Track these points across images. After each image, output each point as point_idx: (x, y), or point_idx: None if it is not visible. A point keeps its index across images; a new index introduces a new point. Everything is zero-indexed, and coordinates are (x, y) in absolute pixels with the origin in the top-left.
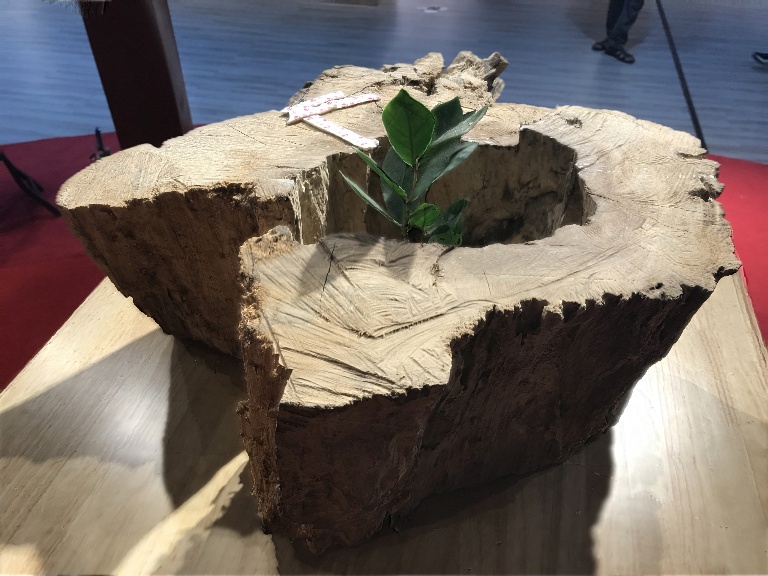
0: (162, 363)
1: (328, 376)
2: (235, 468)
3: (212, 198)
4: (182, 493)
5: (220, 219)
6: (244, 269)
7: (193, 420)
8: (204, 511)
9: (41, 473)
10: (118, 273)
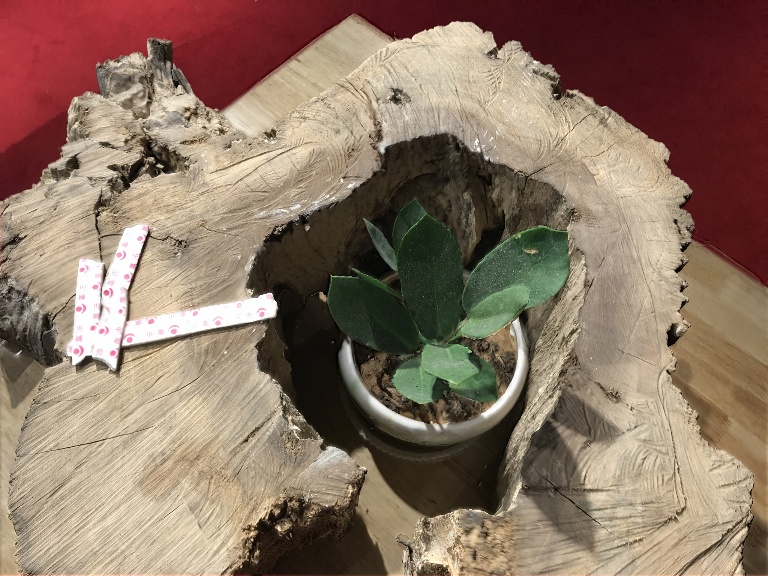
0: None
1: (710, 575)
2: None
3: (258, 559)
4: None
5: None
6: None
7: None
8: None
9: None
10: None
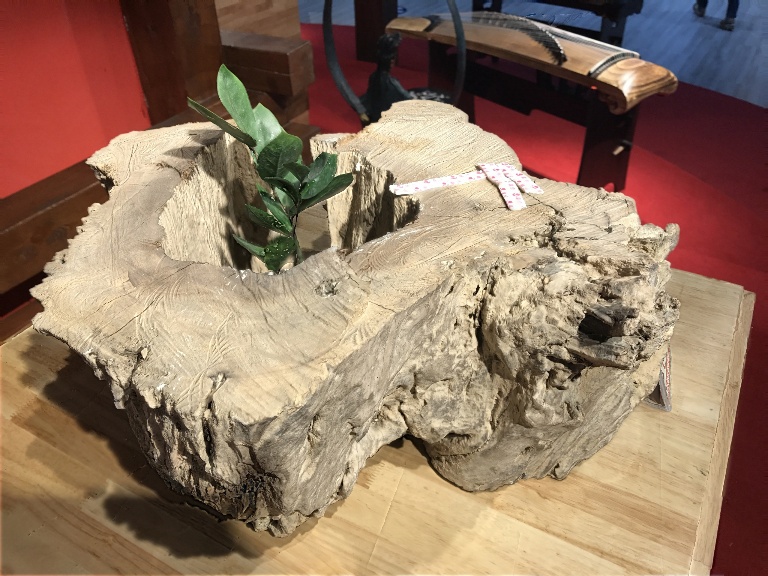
0: None
1: None
2: None
3: None
4: None
5: None
6: None
7: None
8: None
9: None
10: None
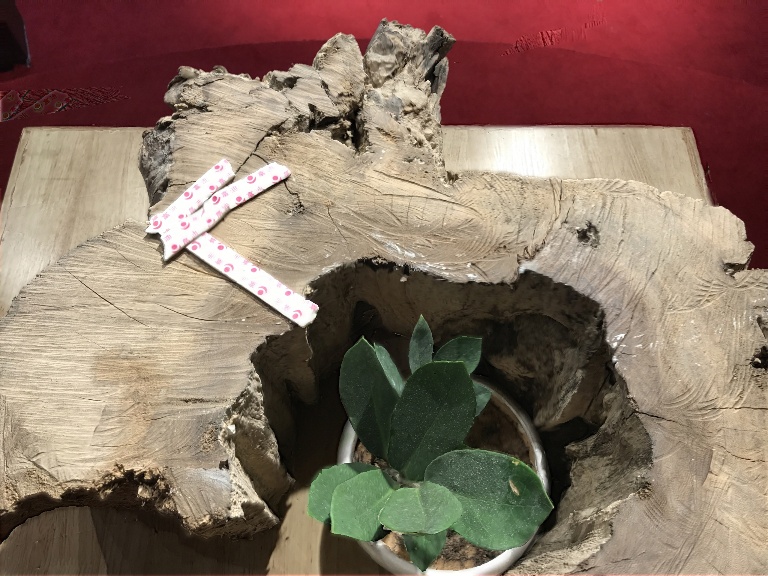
0: (84, 533)
1: None
2: None
3: (106, 496)
4: None
5: None
6: None
7: None
8: None
9: None
10: None
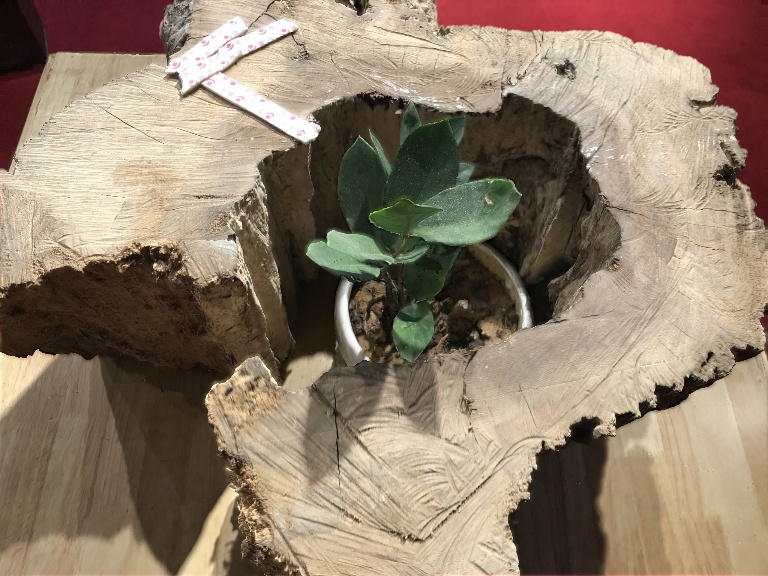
0: (94, 391)
1: None
2: (223, 512)
3: (124, 271)
4: (174, 557)
5: (138, 282)
6: (224, 446)
7: (157, 461)
8: (205, 573)
9: (3, 570)
10: (15, 347)
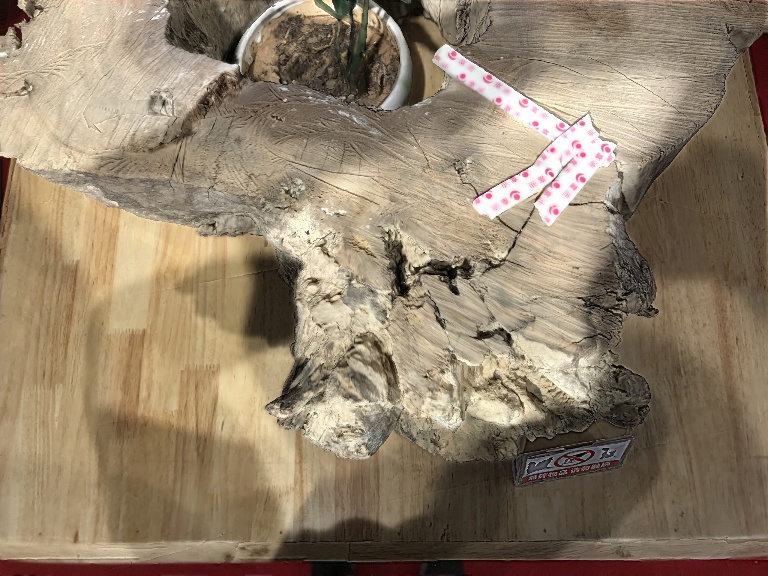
0: None
1: None
2: None
3: None
4: None
5: None
6: None
7: None
8: None
9: None
10: None
